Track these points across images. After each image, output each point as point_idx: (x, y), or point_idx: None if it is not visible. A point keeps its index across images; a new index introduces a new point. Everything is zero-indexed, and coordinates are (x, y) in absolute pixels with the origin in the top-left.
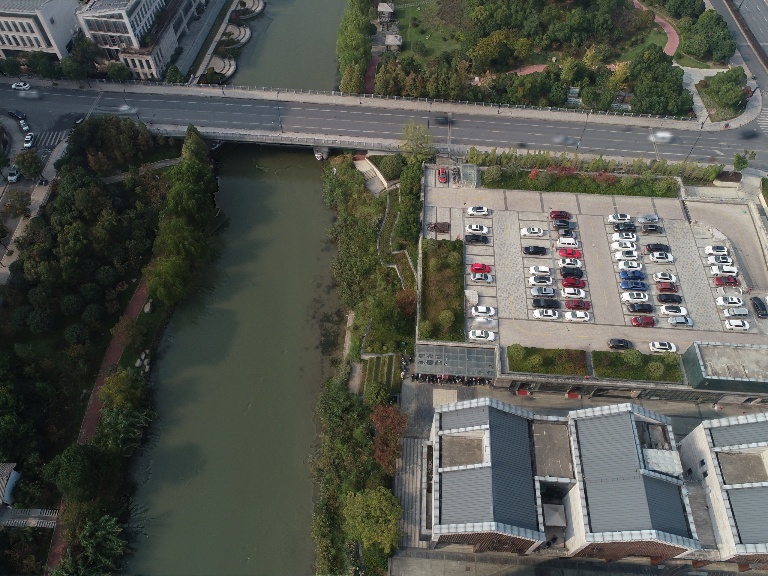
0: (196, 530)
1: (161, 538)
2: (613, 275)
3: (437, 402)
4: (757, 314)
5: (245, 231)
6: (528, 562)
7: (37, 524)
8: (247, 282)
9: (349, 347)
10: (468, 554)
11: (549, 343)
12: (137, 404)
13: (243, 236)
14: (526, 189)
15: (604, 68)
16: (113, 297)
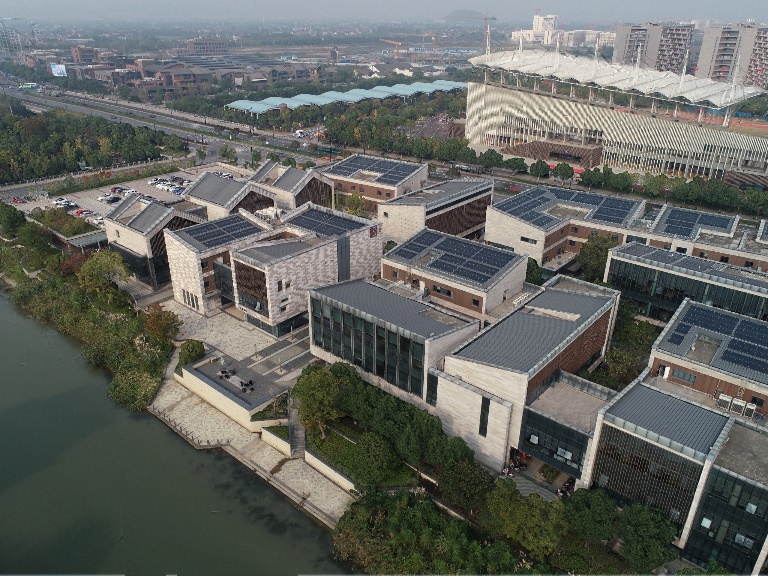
0: None
1: None
2: (169, 194)
3: None
4: None
5: None
6: None
7: None
8: None
9: (14, 282)
10: None
11: None
12: None
13: None
14: (86, 189)
15: (93, 152)
16: None
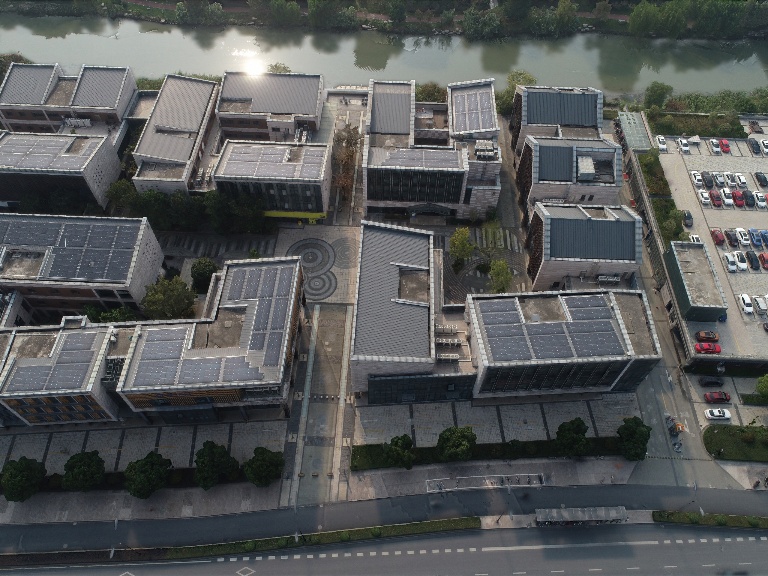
0: (500, 58)
1: (493, 48)
2: (762, 228)
3: (603, 135)
4: (767, 322)
5: (705, 57)
6: (510, 168)
7: (491, 6)
8: (662, 61)
9: None
10: (509, 144)
11: (671, 179)
12: (560, 27)
13: (700, 56)
14: None
15: None
16: (623, 4)
